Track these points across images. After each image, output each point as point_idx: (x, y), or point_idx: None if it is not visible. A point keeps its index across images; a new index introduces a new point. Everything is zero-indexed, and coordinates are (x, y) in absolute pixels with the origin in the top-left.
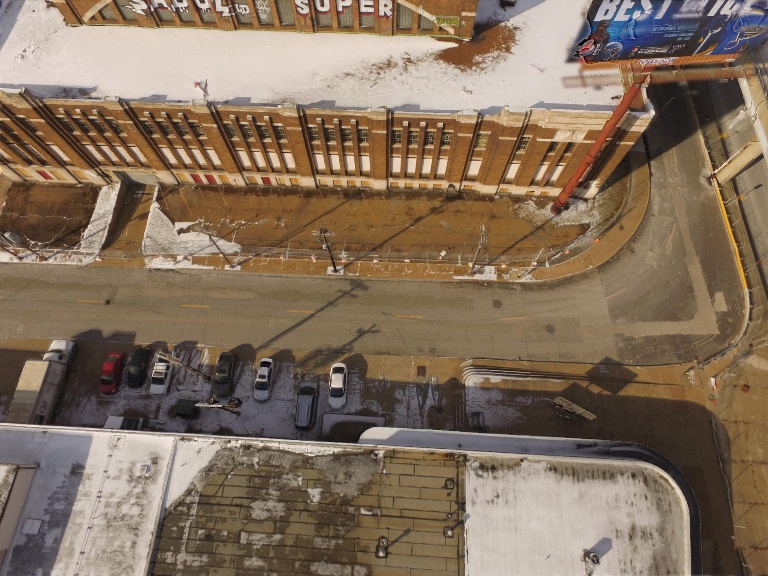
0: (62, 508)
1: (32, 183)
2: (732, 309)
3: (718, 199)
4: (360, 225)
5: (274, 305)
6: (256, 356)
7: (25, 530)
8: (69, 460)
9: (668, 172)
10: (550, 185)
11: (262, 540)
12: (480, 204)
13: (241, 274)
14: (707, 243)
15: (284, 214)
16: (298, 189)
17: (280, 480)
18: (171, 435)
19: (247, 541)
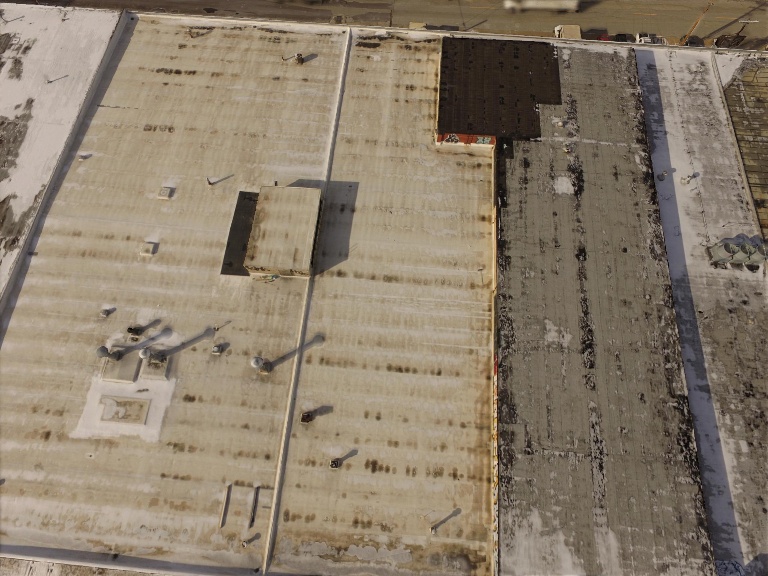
0: (652, 84)
1: None
2: None
3: None
4: None
5: (704, 14)
6: (704, 42)
7: None
8: (643, 62)
9: None
10: None
11: None
12: None
13: None
14: None
15: None
16: None
17: None
18: (711, 49)
19: None
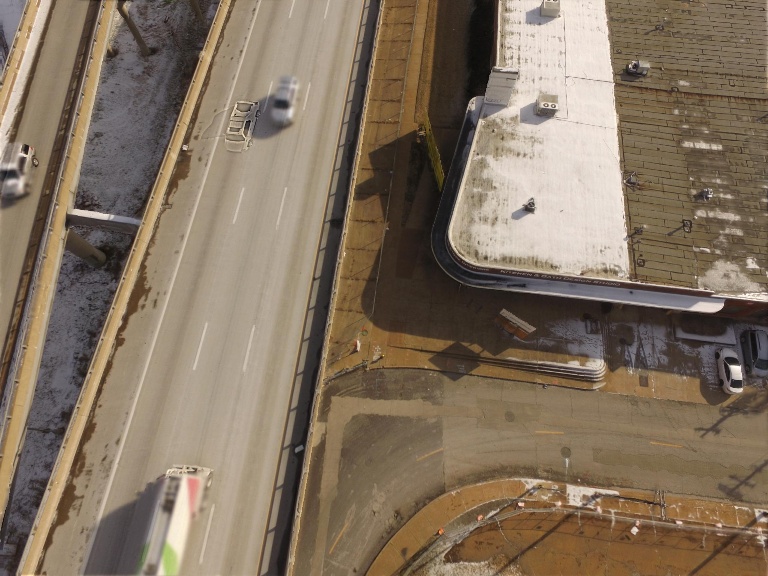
0: None
1: None
2: None
3: None
4: None
5: None
6: None
7: None
8: None
9: None
10: None
11: None
12: None
13: None
14: None
15: None
16: None
17: None
18: None
19: None
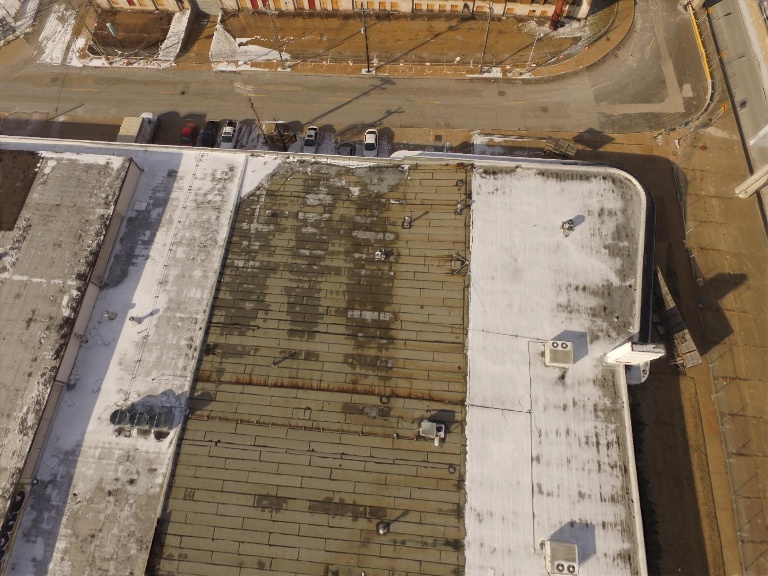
0: (162, 196)
1: (118, 10)
2: (697, 95)
3: (691, 20)
4: (389, 39)
5: (318, 95)
6: (304, 129)
7: (135, 207)
8: (166, 168)
9: (650, 2)
10: (549, 3)
11: (315, 217)
12: (490, 23)
13: (291, 74)
14: (680, 51)
15: (326, 32)
16: (338, 13)
17: (328, 182)
18: (244, 151)
19: (303, 217)
